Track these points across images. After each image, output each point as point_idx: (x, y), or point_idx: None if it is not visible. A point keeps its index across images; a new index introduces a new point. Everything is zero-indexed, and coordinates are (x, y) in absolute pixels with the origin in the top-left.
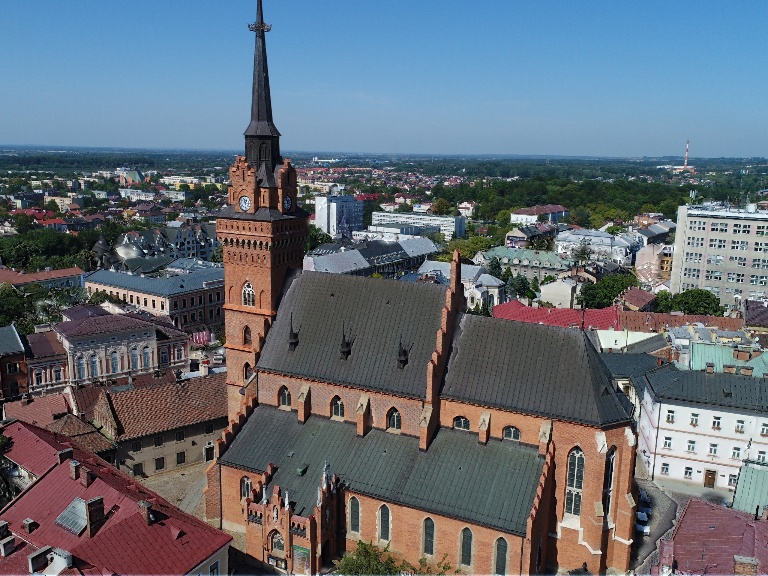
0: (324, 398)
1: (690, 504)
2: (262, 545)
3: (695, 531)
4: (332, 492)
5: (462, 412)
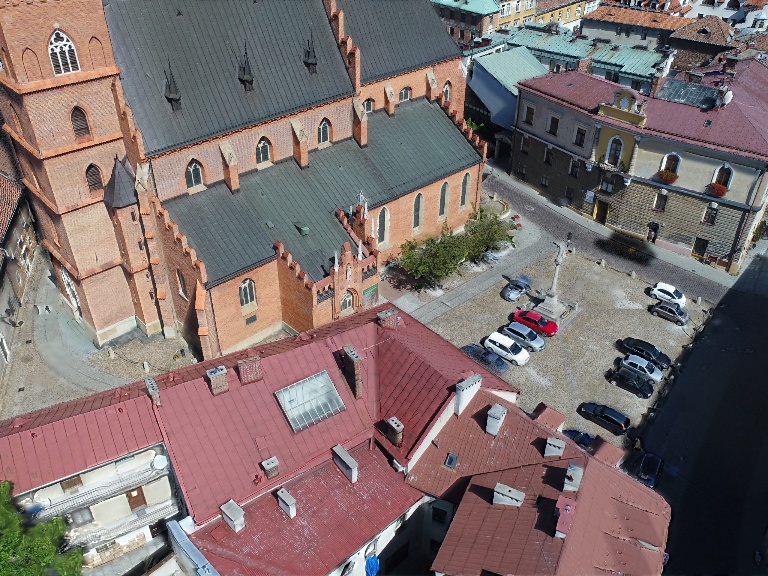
0: (248, 148)
1: (527, 84)
2: (333, 318)
3: (568, 92)
4: (352, 225)
5: (369, 94)
